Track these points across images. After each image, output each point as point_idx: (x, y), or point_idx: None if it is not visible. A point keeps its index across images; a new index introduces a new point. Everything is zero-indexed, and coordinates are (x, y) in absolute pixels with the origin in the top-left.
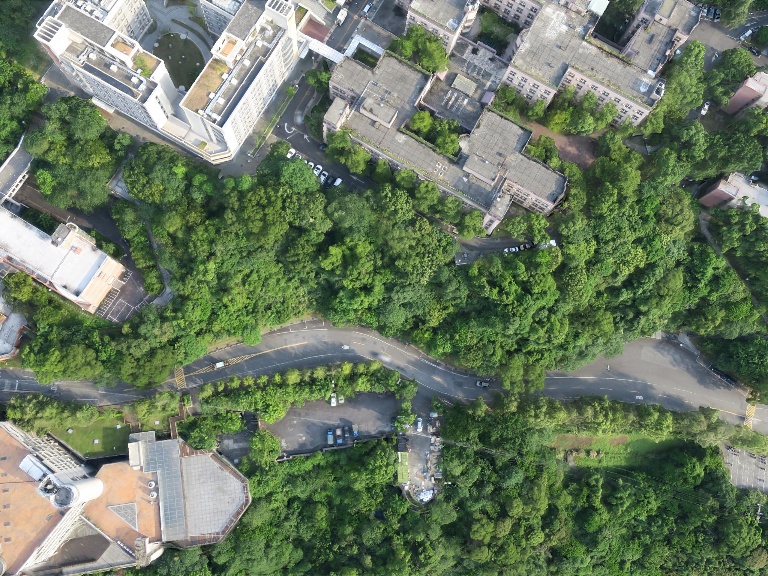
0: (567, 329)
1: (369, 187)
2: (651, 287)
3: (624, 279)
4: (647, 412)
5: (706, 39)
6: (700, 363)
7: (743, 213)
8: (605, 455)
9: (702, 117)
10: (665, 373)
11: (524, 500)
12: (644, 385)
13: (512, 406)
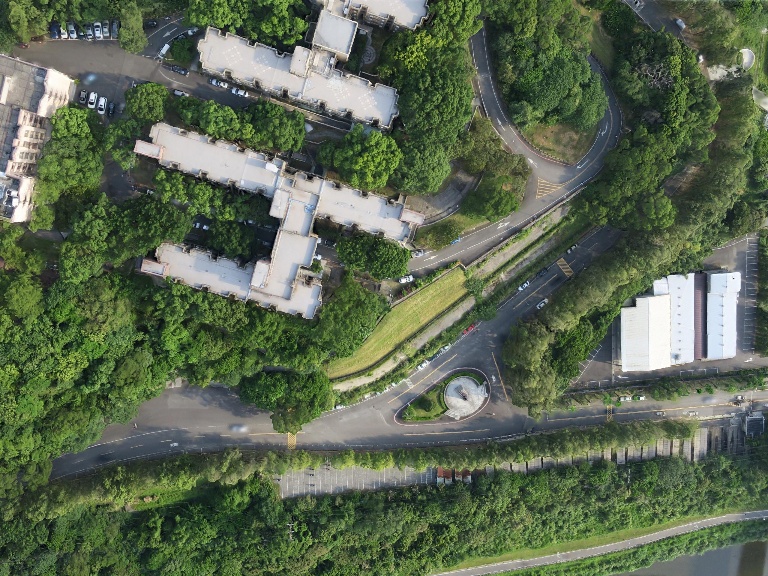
0: (30, 442)
1: None
2: (106, 381)
3: (79, 377)
4: (158, 477)
5: (117, 67)
6: (233, 395)
7: (172, 294)
8: (162, 496)
9: (131, 170)
10: (197, 415)
11: (64, 575)
12: (177, 432)
13: (5, 518)
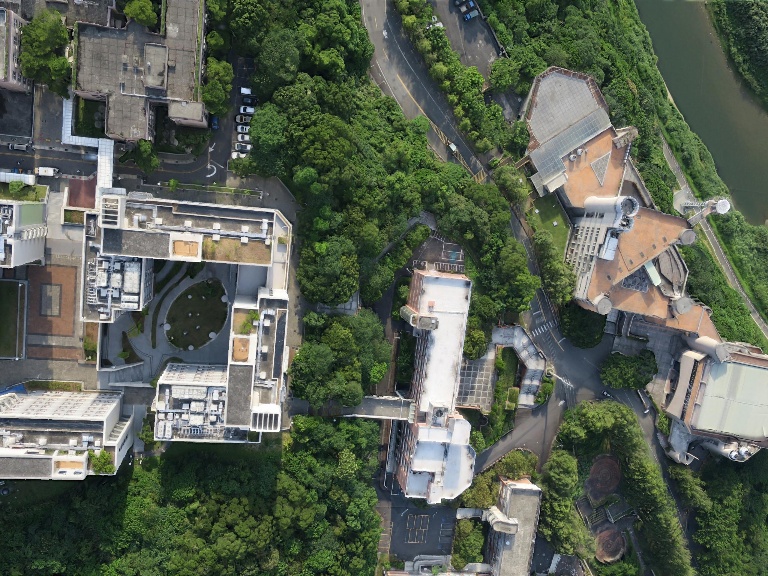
0: None
1: (238, 52)
2: None
3: None
4: None
5: None
6: None
7: None
8: None
9: None
10: None
11: None
12: None
13: None
